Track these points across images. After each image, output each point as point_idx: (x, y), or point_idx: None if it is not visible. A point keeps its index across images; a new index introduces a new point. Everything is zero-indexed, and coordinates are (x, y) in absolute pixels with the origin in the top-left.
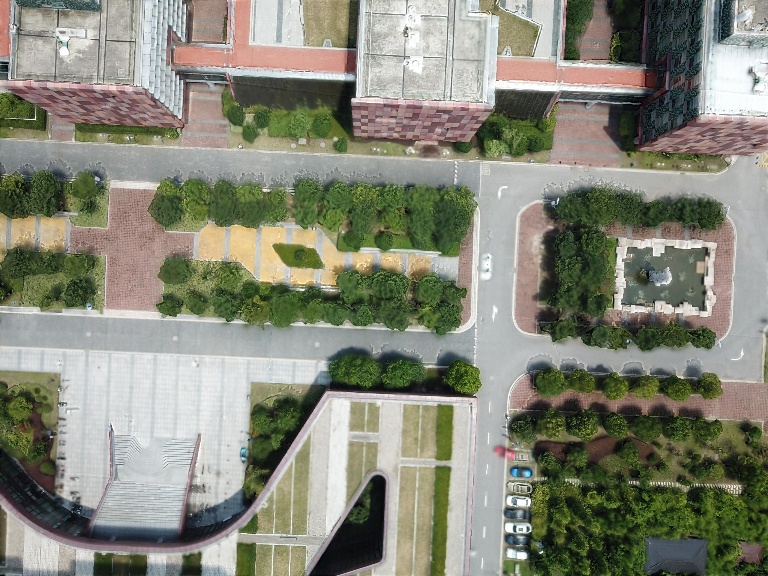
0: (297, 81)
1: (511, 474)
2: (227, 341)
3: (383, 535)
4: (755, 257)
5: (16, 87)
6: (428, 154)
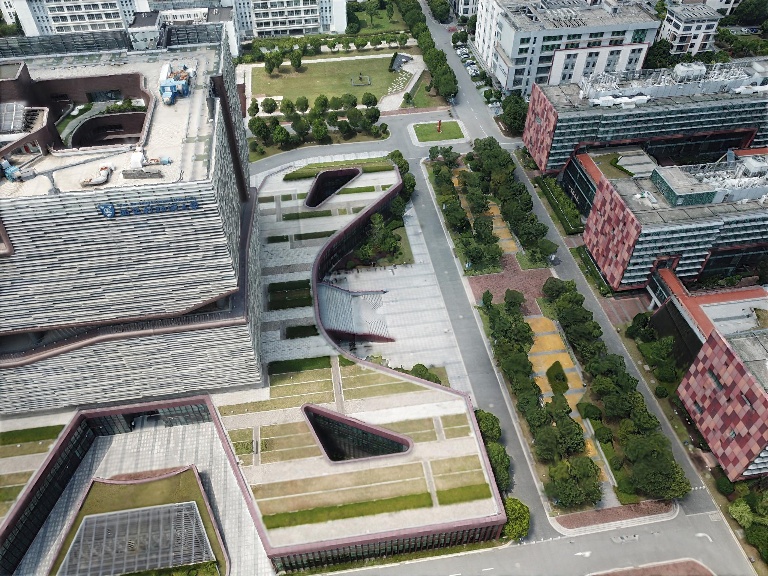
0: (694, 337)
1: None
2: (471, 346)
3: None
4: None
5: (604, 183)
6: (696, 461)
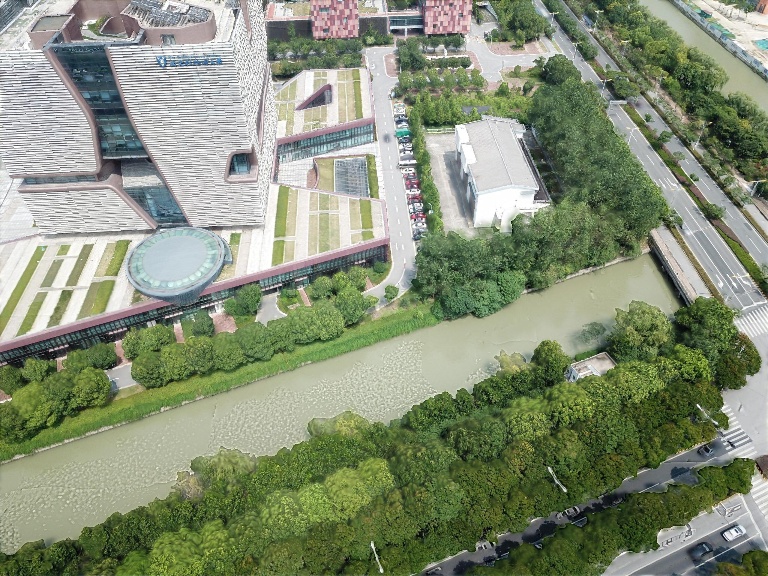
0: None
1: (394, 107)
2: None
3: (331, 97)
4: (486, 58)
5: None
6: None
